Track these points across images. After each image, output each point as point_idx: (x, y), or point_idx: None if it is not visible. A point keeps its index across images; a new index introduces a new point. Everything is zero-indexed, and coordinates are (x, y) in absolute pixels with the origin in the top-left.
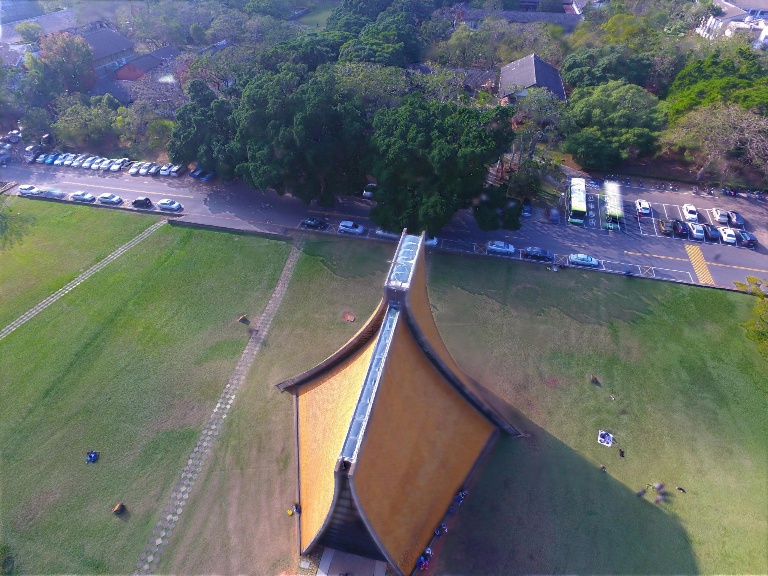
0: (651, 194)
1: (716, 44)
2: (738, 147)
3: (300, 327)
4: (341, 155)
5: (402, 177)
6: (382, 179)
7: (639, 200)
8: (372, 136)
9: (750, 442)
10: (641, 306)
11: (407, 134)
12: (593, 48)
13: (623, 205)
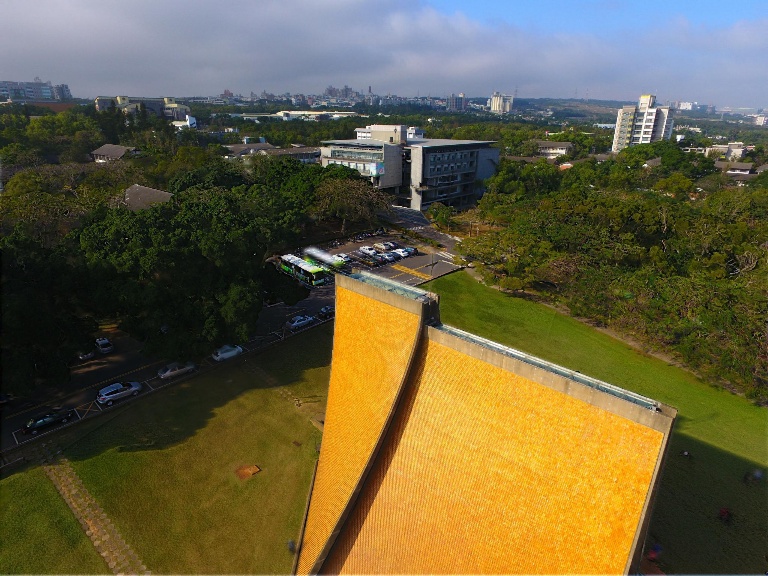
0: (333, 251)
1: (269, 158)
2: (367, 198)
3: (204, 533)
4: (49, 302)
5: (173, 289)
6: (150, 300)
7: (335, 255)
8: (88, 262)
9: (552, 332)
10: None
11: (151, 240)
12: (190, 171)
13: (329, 263)
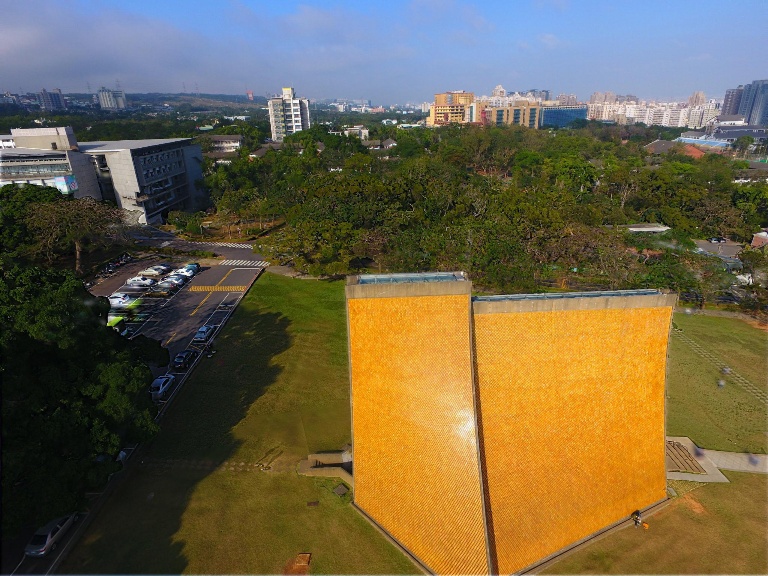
0: None
1: None
2: None
3: None
4: None
5: (7, 409)
6: None
7: None
8: None
9: None
10: (272, 316)
11: None
12: None
13: None
